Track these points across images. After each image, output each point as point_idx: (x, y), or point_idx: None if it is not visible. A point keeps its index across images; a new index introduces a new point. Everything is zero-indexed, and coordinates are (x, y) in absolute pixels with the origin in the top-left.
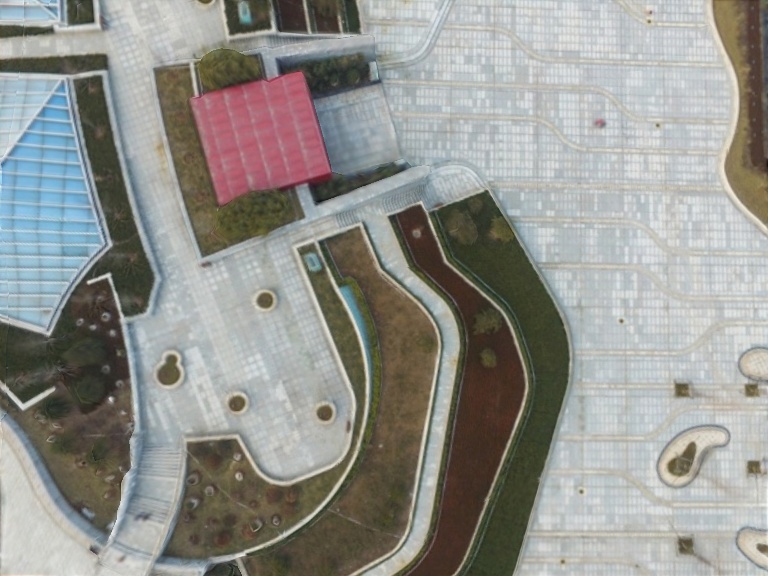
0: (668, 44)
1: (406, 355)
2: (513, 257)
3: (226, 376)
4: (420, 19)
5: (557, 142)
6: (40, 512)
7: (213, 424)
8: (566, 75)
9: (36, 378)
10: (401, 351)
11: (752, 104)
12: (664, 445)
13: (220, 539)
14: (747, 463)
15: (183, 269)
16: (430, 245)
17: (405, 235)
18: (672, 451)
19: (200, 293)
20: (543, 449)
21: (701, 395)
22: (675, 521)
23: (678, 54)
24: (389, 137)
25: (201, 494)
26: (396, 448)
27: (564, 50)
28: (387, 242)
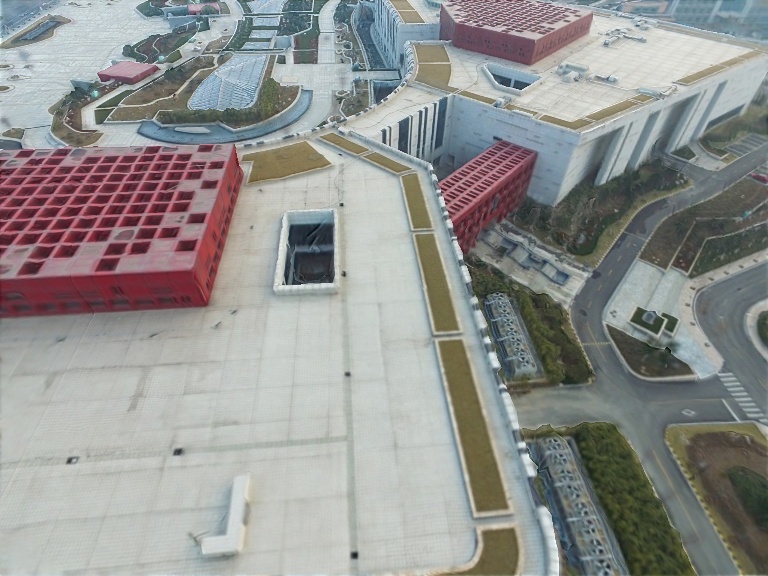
0: None
1: None
2: None
3: None
4: None
5: None
6: None
7: None
8: None
9: None
10: (181, 0)
11: None
12: (119, 1)
13: None
14: None
15: None
16: None
17: None
18: (117, 0)
19: None
20: None
21: None
22: None
23: None
24: None
25: None
26: None
27: None
28: None
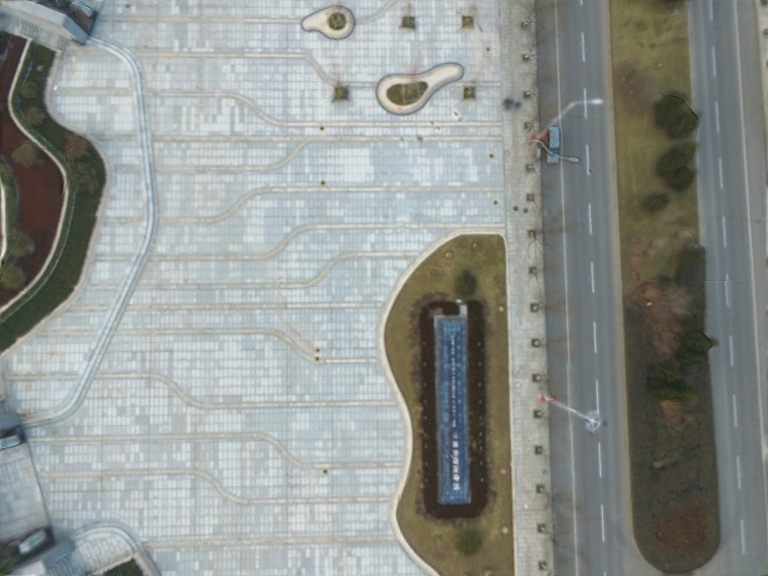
0: (337, 382)
1: None
2: None
3: None
4: (68, 372)
5: (216, 495)
6: None
7: None
8: (227, 422)
9: None
10: None
11: (424, 446)
12: None
13: None
14: None
15: None
16: None
17: None
18: None
19: None
20: None
21: None
22: None
23: (348, 393)
24: (34, 500)
25: None
26: None
27: (225, 395)
28: None
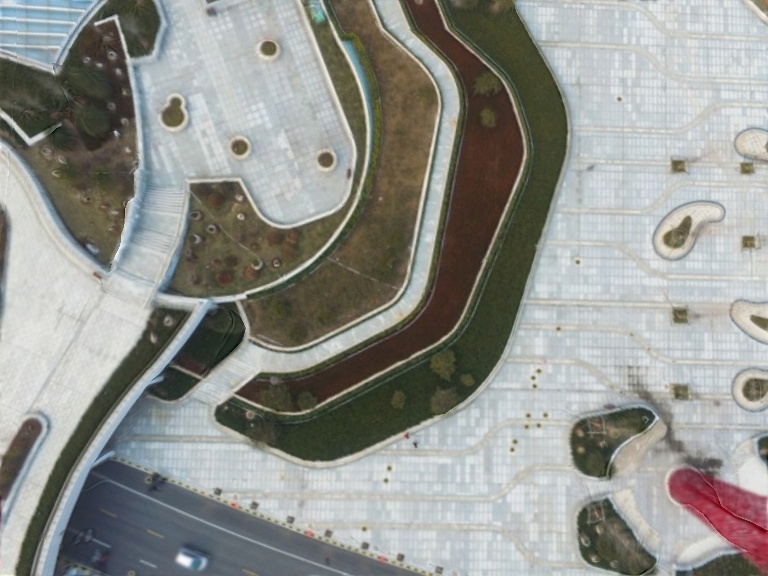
0: None
1: (406, 112)
2: (513, 29)
3: (229, 123)
4: None
5: None
6: (45, 240)
7: (216, 169)
8: None
9: (43, 113)
10: (402, 108)
11: None
12: (660, 219)
13: (221, 276)
14: (742, 238)
15: (188, 18)
16: (432, 12)
17: (407, 1)
18: (668, 224)
19: (205, 41)
20: (540, 217)
21: (697, 172)
22: (670, 292)
23: None
24: None
25: (203, 232)
26: (395, 201)
27: None
28: (389, 4)
